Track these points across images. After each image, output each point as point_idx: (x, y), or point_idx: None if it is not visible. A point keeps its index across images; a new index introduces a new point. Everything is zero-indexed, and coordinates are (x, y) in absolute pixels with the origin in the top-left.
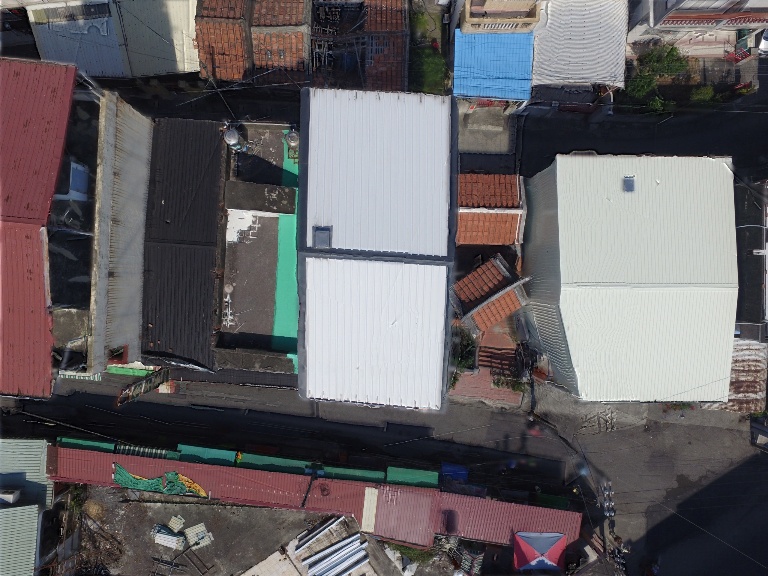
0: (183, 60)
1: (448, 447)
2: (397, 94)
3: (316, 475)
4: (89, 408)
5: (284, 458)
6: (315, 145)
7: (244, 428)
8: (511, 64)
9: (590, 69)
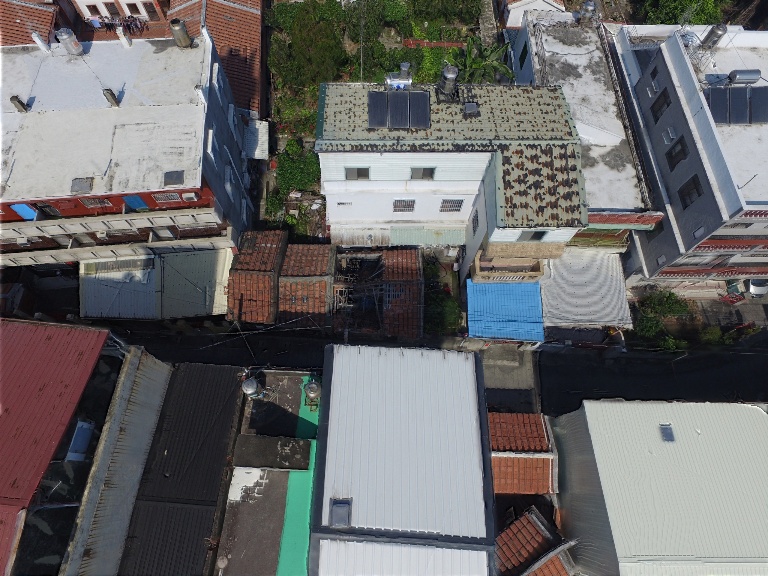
0: (212, 304)
1: None
2: (420, 351)
3: None
4: None
5: None
6: (337, 403)
7: None
8: (521, 309)
9: (598, 313)
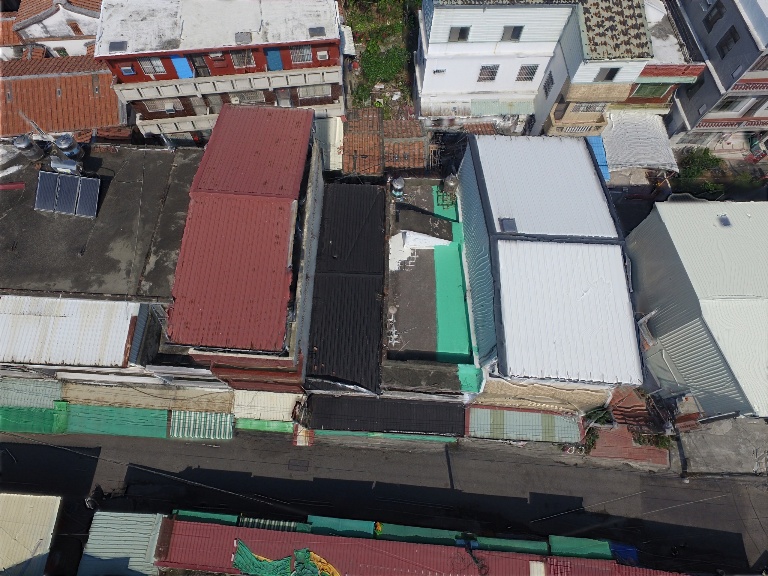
0: (329, 162)
1: (603, 521)
2: (542, 137)
3: (470, 547)
4: (200, 487)
5: (429, 528)
6: (487, 167)
7: (371, 505)
8: None
9: (651, 158)
